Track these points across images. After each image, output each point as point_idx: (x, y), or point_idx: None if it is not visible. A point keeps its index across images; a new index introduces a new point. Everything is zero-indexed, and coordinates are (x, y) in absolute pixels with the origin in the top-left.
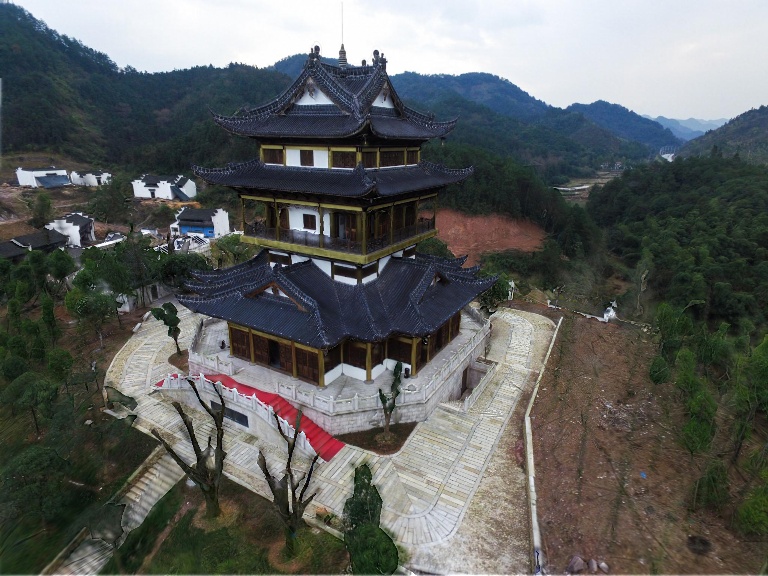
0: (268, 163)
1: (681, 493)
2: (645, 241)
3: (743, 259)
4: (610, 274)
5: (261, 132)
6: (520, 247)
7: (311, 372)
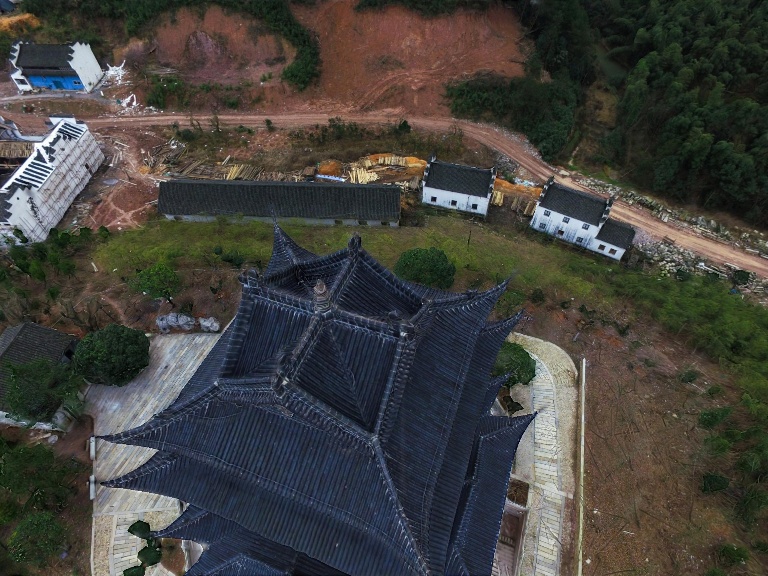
0: None
1: None
2: (640, 36)
3: (748, 75)
4: (591, 79)
5: (211, 462)
6: (493, 64)
7: None
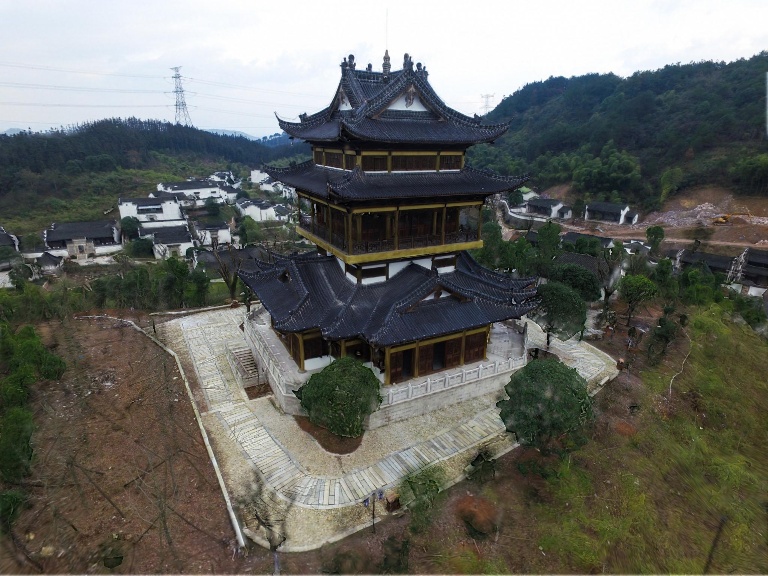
0: None
1: None
2: None
3: None
4: None
5: None
6: None
7: None
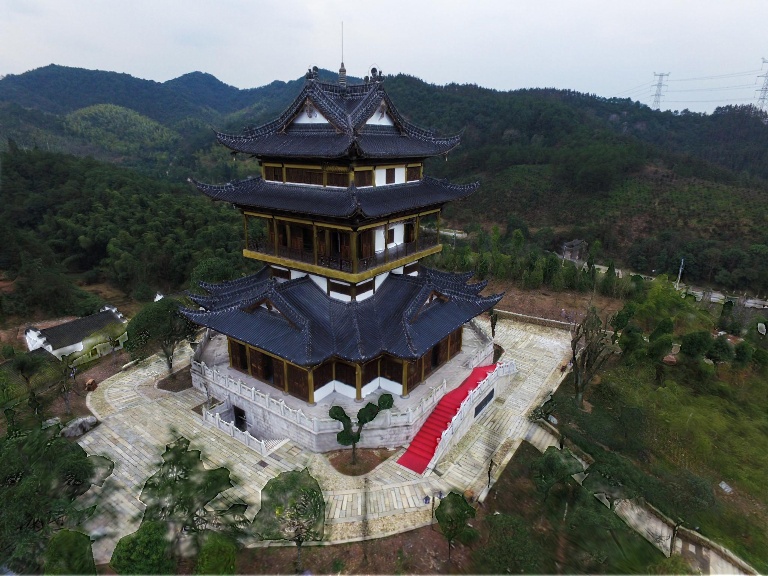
0: (358, 187)
1: (520, 290)
2: (84, 241)
3: (182, 233)
4: None
5: None
6: None
7: (456, 346)
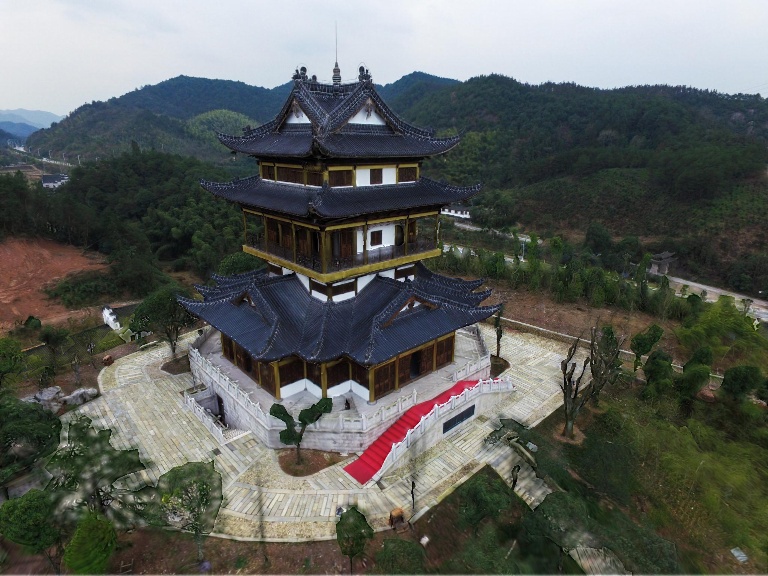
0: (334, 186)
1: None
2: (175, 232)
3: (259, 228)
4: None
5: (357, 153)
6: (76, 268)
7: (446, 356)
